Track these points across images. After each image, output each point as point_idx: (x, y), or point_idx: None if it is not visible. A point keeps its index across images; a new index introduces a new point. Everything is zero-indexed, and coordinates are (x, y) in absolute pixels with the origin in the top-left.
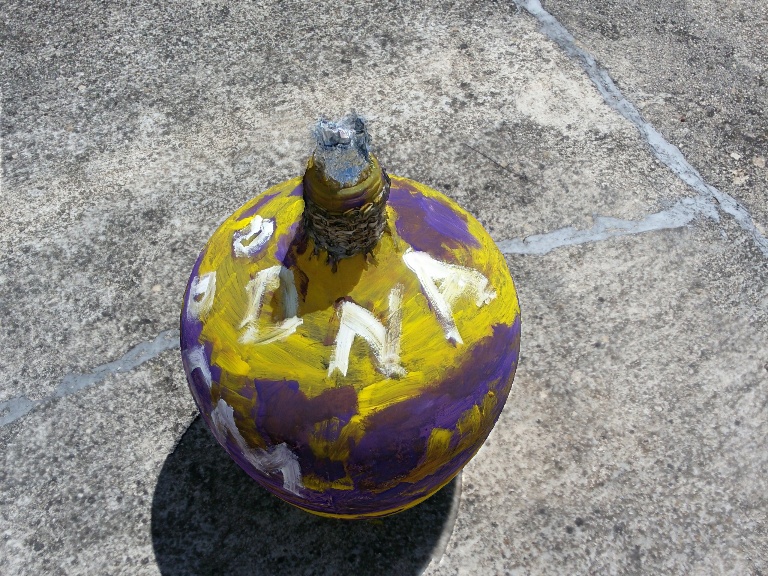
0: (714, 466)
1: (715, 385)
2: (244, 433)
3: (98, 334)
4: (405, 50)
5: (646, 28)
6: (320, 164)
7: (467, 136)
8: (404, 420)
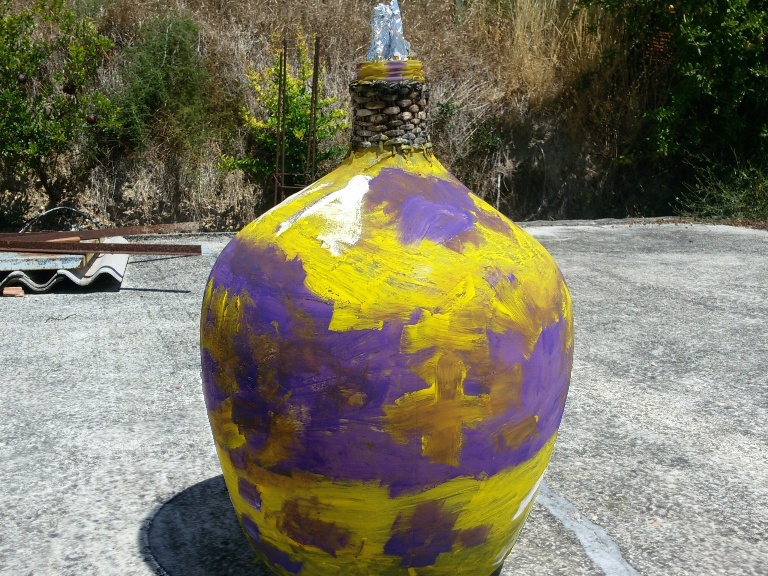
0: None
1: None
2: None
3: None
4: None
5: None
6: None
7: None
8: None
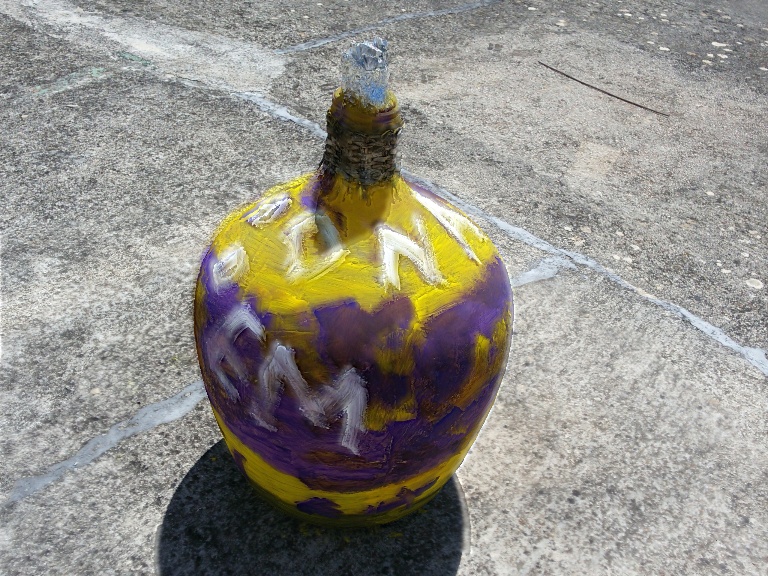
0: (661, 430)
1: (632, 375)
2: (308, 374)
3: (42, 439)
4: (271, 192)
5: (462, 161)
6: (354, 99)
7: None
8: (457, 325)
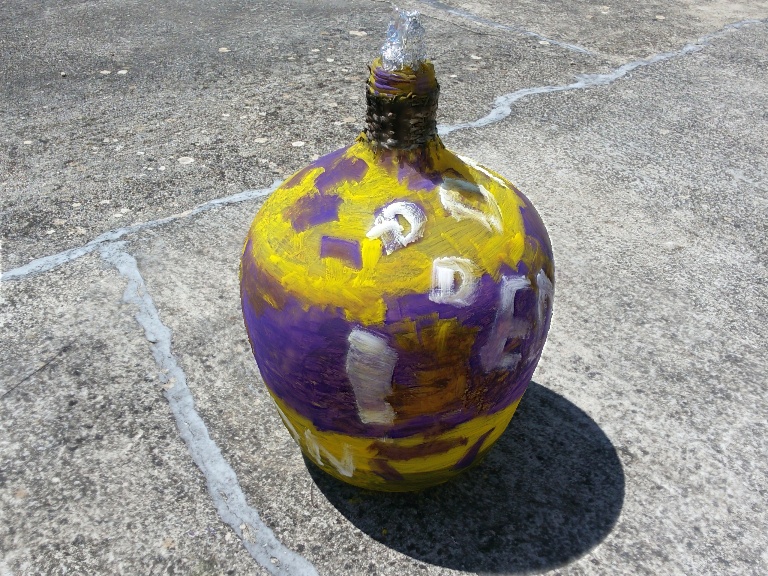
0: None
1: None
2: None
3: None
4: None
5: None
6: (414, 66)
7: None
8: None
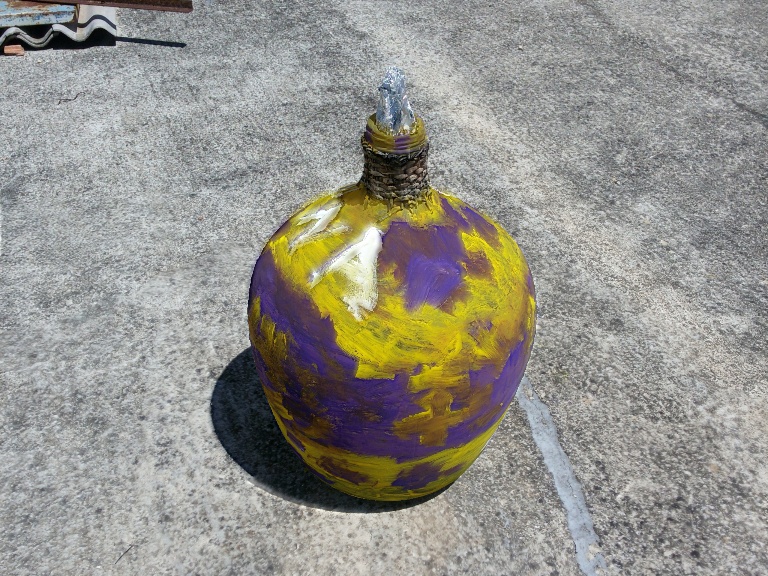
0: None
1: None
2: None
3: None
4: None
5: None
6: None
7: None
8: None
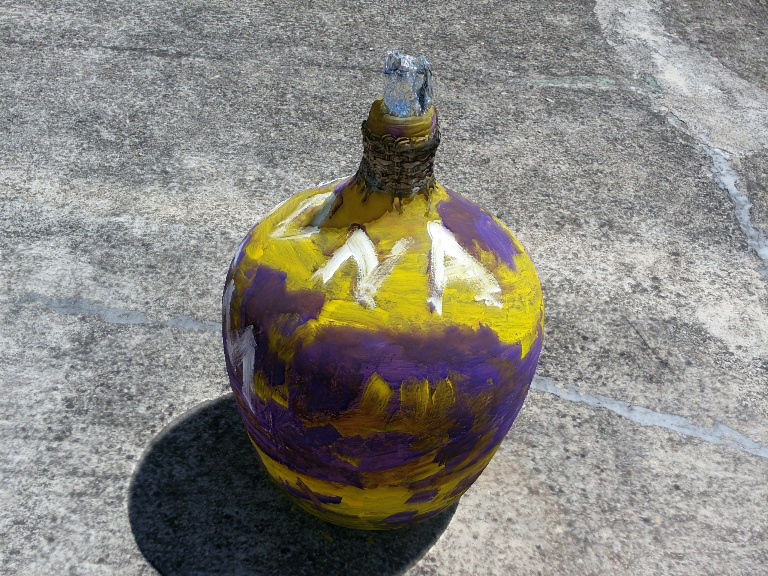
0: None
1: None
2: (232, 312)
3: None
4: (619, 236)
5: None
6: None
7: (631, 312)
8: (351, 345)
